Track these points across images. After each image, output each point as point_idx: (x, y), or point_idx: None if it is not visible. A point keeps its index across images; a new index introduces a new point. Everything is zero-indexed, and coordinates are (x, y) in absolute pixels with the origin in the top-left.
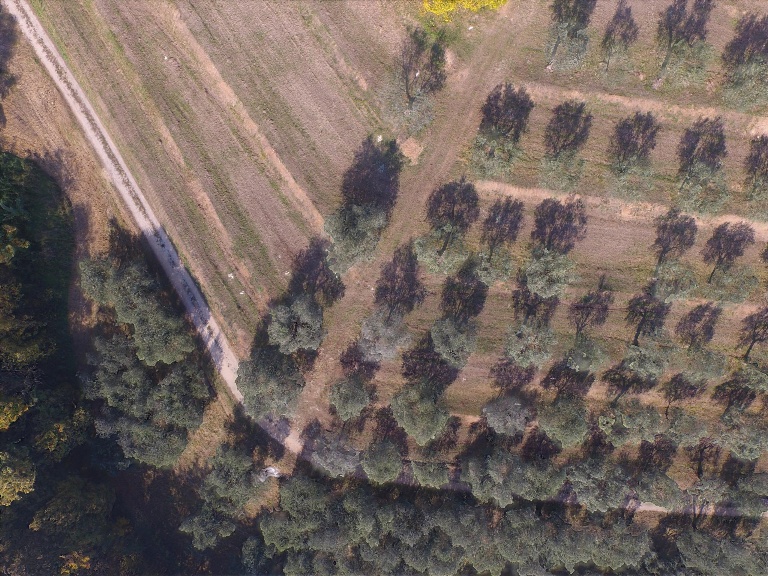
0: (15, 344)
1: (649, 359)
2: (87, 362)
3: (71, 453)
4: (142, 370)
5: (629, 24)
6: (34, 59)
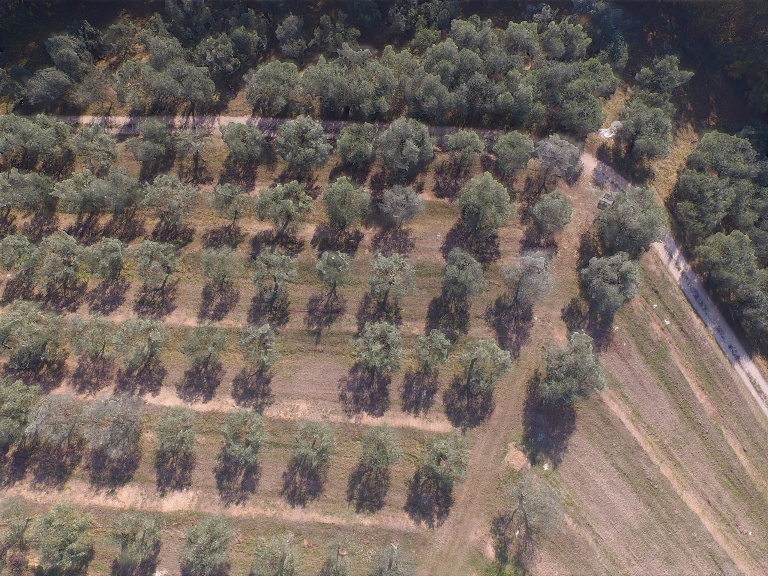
0: None
1: (279, 268)
2: None
3: None
4: (739, 224)
5: None
6: None
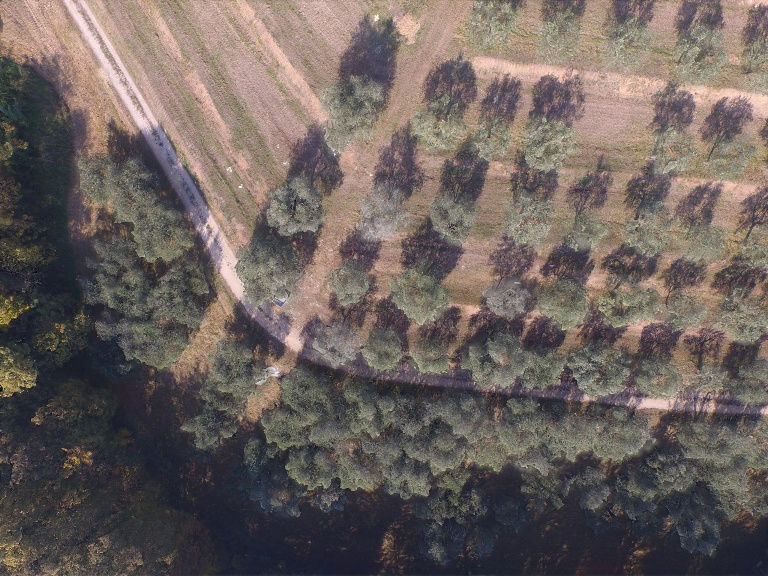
0: (15, 243)
1: (648, 231)
2: (87, 265)
3: (72, 361)
4: (142, 271)
5: None
6: None
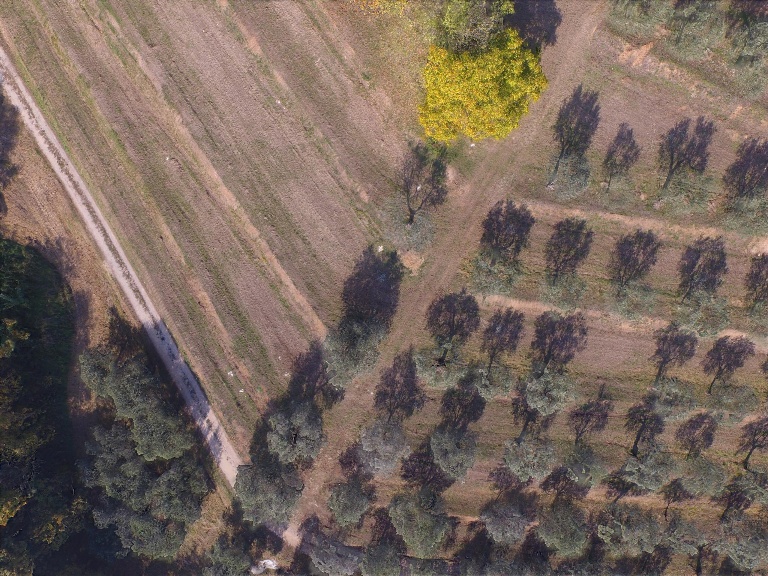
0: (14, 438)
1: (648, 476)
2: (86, 451)
3: (69, 538)
4: (141, 461)
5: (631, 146)
6: (36, 150)
